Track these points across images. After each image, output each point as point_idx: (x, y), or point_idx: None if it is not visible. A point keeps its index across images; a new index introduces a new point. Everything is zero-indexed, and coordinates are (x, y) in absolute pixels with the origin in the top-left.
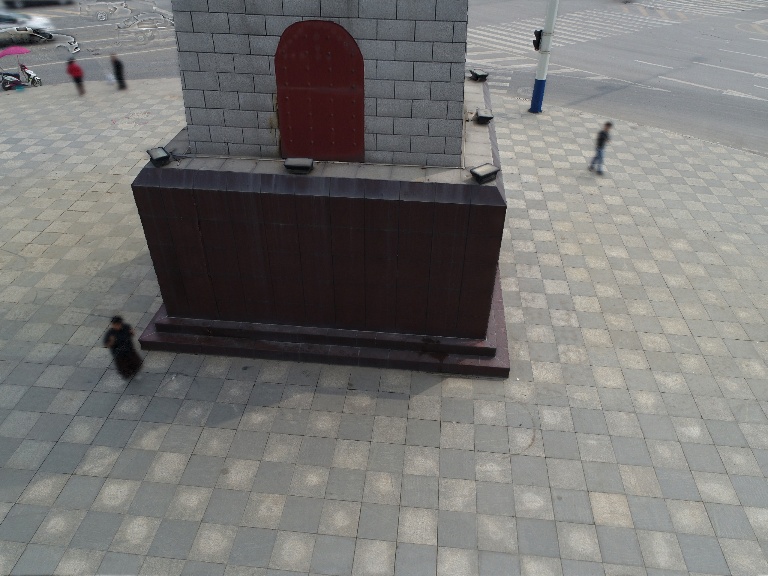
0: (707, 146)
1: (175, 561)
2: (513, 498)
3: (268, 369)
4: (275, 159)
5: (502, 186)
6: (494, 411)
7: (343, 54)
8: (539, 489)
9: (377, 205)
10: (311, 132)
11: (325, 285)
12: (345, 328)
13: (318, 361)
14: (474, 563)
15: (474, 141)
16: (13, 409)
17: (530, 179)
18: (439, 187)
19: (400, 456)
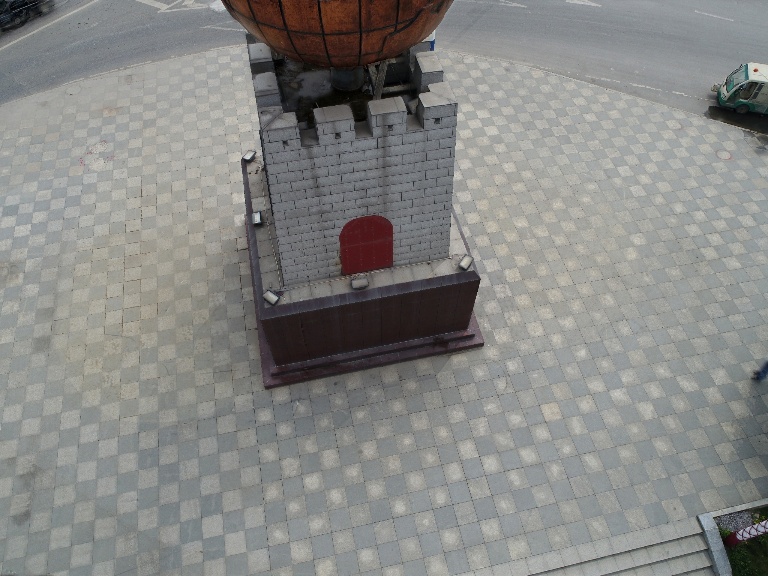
0: (562, 83)
1: (363, 504)
2: (506, 420)
3: (349, 380)
4: (340, 278)
5: None
6: (482, 371)
7: (381, 226)
8: (517, 411)
9: (409, 294)
10: (361, 261)
11: (376, 331)
12: (387, 344)
13: (376, 367)
14: (498, 459)
15: None
16: (219, 453)
17: None
18: (443, 278)
19: (445, 414)
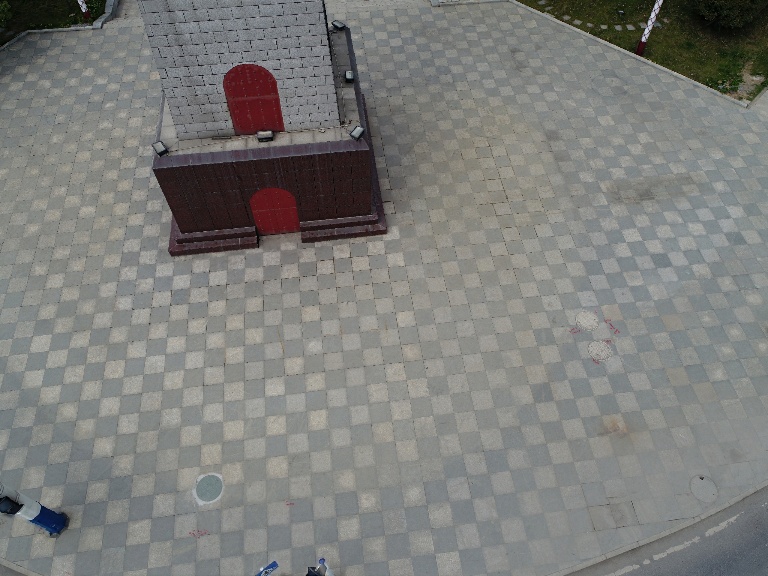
0: None
1: None
2: None
3: None
4: None
5: None
6: None
7: None
8: None
9: None
10: None
11: None
12: None
13: None
14: None
15: None
16: (396, 70)
17: (124, 301)
18: None
19: None
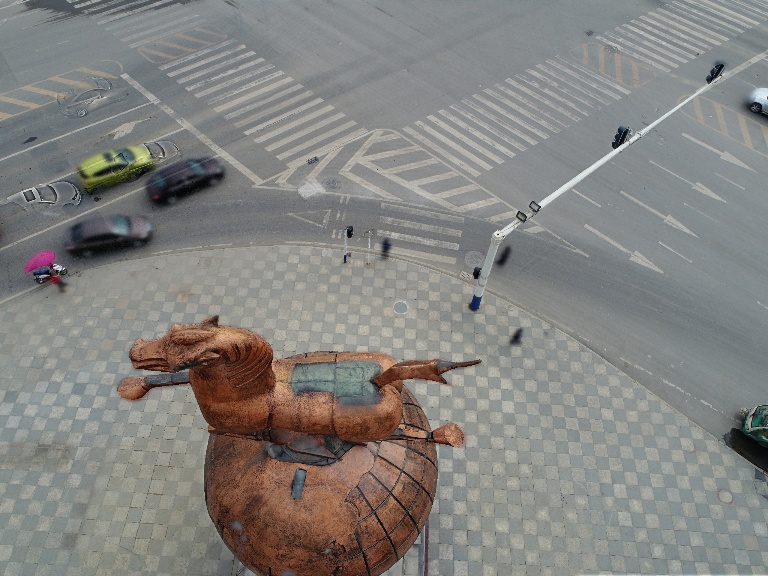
0: (594, 363)
1: None
2: None
3: None
4: None
5: None
6: None
7: None
8: None
9: None
10: None
11: None
12: None
13: None
14: None
15: (409, 573)
16: None
17: None
18: None
19: None
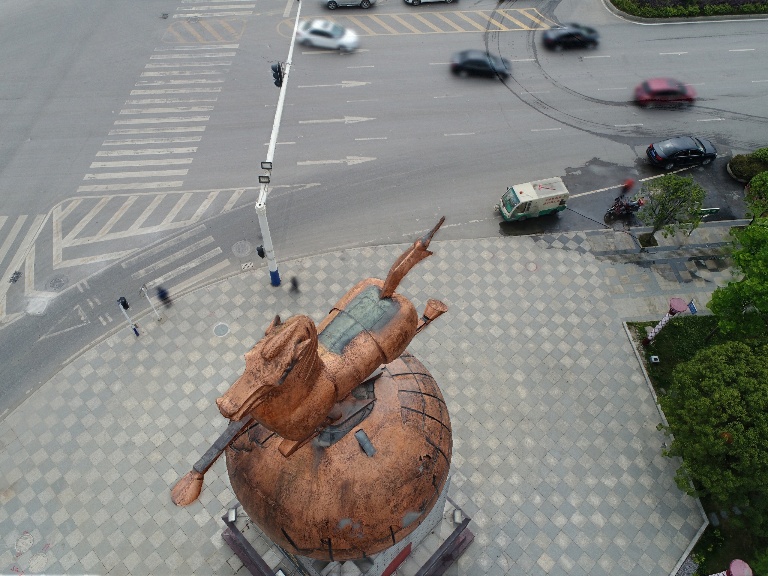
0: (390, 252)
1: None
2: None
3: None
4: None
5: (459, 508)
6: (485, 560)
7: None
8: None
9: None
10: None
11: None
12: None
13: None
14: None
15: None
16: None
17: None
18: None
19: None
